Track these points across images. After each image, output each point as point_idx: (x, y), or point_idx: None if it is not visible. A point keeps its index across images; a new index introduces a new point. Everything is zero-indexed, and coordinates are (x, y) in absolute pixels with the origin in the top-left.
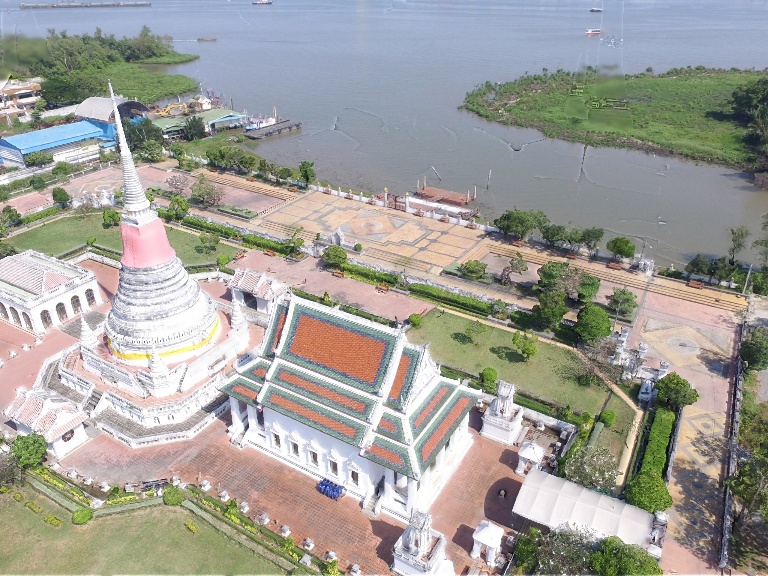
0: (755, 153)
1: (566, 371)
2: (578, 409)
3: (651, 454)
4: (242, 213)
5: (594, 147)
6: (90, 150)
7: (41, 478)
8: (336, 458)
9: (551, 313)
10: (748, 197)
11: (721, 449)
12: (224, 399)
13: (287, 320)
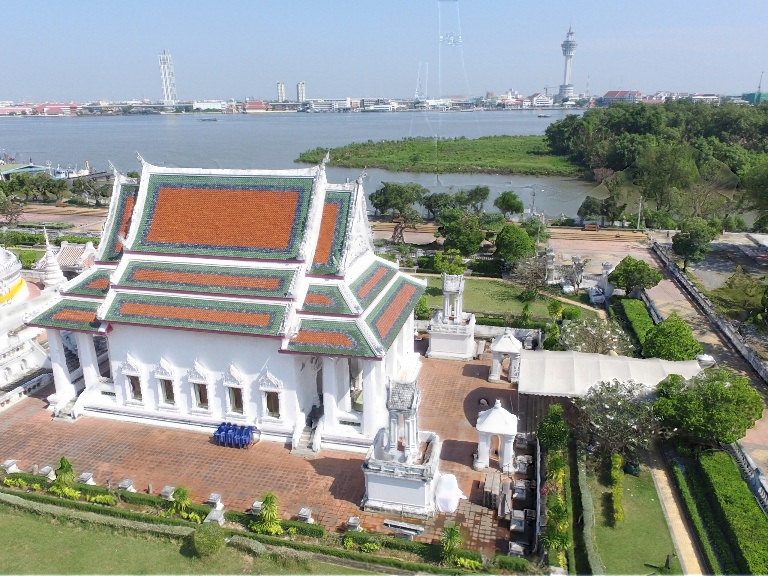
0: (582, 167)
1: (501, 294)
2: (535, 315)
3: (642, 330)
4: (52, 224)
5: (439, 174)
6: None
7: None
8: (239, 379)
9: (467, 241)
10: None
11: (705, 323)
12: (38, 375)
13: (138, 198)
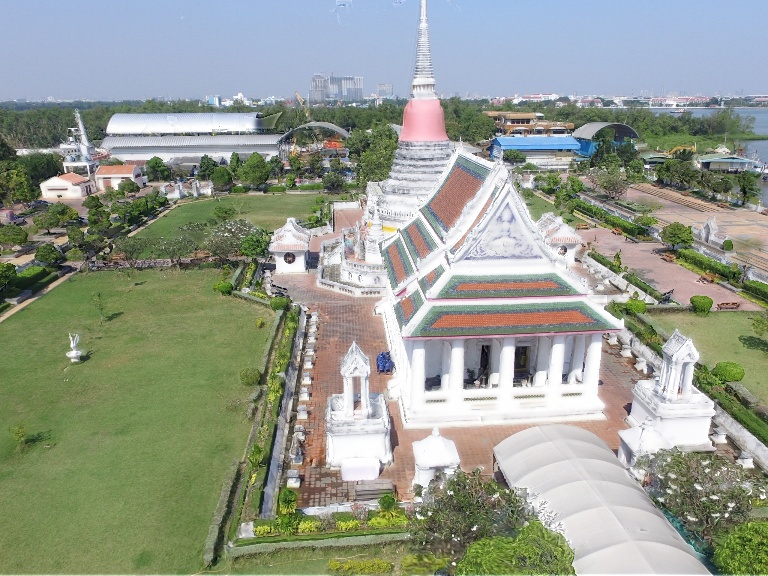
0: None
1: None
2: None
3: None
4: (633, 206)
5: None
6: (562, 161)
7: None
8: None
9: None
10: None
11: None
12: None
13: (445, 172)
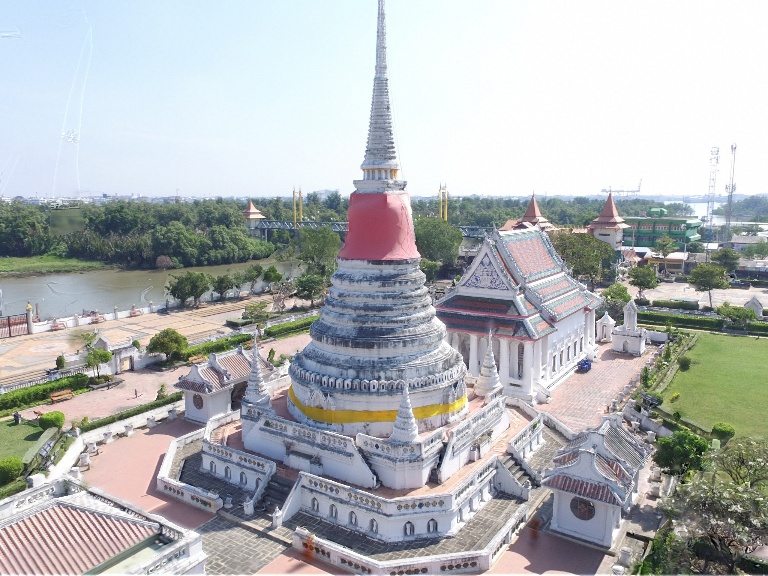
0: (96, 261)
1: None
2: None
3: None
4: None
5: None
6: None
7: (694, 479)
8: None
9: None
10: (158, 279)
11: None
12: None
13: None
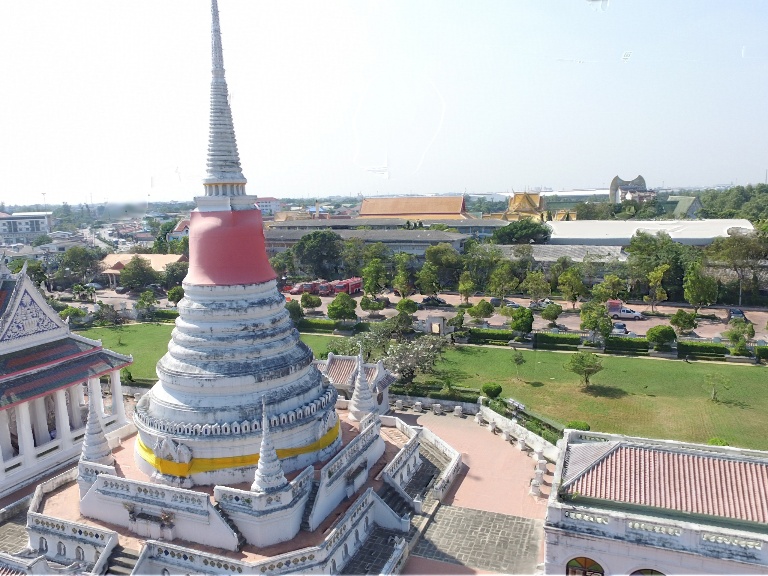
0: None
1: None
2: None
3: None
4: None
5: None
6: None
7: None
8: None
9: None
10: None
11: None
12: None
13: None
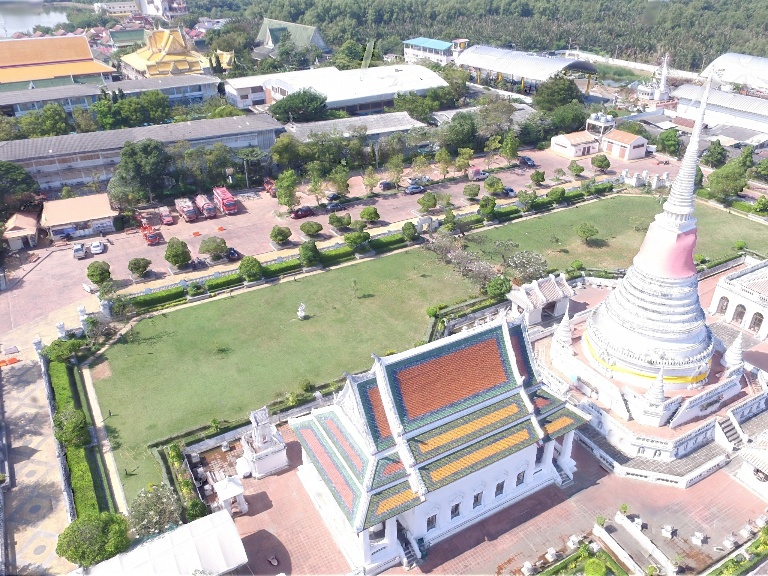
0: None
1: None
2: None
3: None
4: None
5: None
6: None
7: None
8: None
9: None
10: None
11: None
12: None
13: None
